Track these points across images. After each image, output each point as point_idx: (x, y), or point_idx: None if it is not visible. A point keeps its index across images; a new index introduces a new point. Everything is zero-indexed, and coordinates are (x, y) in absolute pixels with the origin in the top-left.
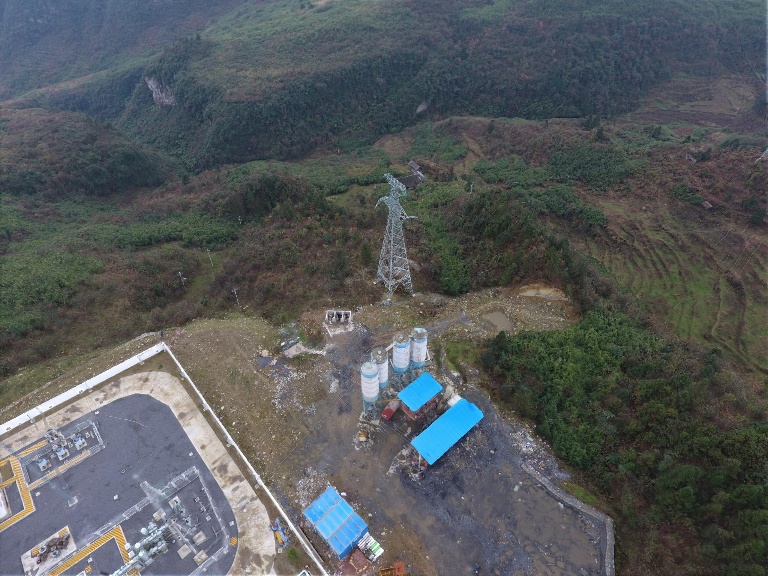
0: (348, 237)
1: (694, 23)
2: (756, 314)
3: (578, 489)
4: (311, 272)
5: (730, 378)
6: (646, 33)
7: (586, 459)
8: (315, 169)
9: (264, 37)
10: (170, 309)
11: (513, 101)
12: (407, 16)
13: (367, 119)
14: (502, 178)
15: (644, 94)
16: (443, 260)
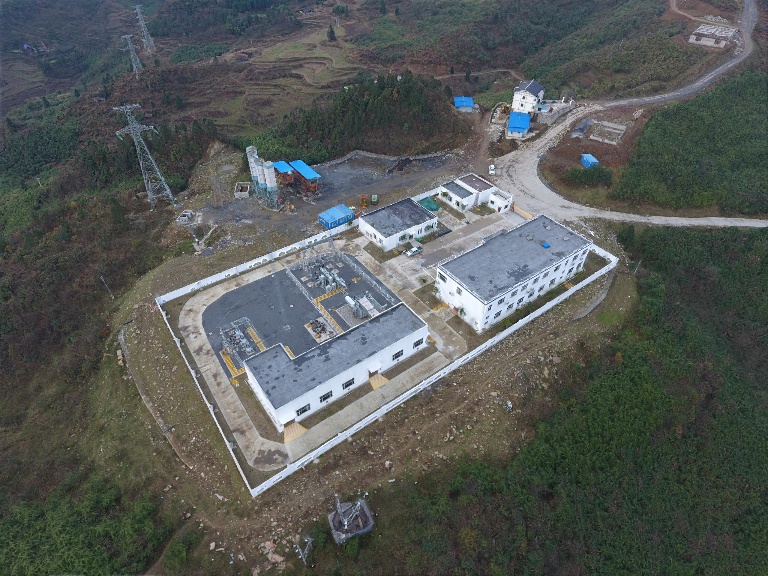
0: (72, 225)
1: None
2: None
3: None
4: None
5: None
6: None
7: None
8: None
9: None
10: (69, 355)
11: None
12: None
13: None
14: None
15: None
16: None
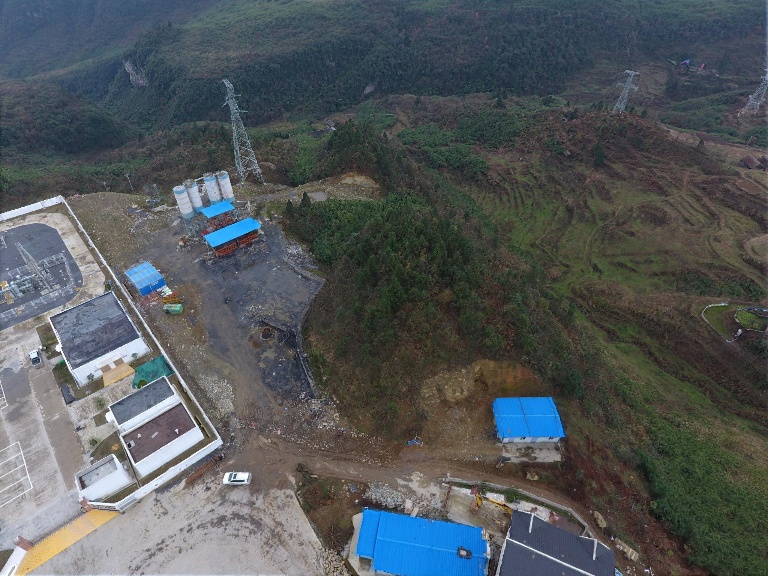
0: None
1: (615, 15)
2: (576, 229)
3: (318, 272)
4: (190, 168)
5: (455, 220)
6: (571, 24)
7: (332, 259)
8: (251, 129)
9: (228, 25)
10: None
11: (450, 83)
12: (358, 7)
13: (318, 98)
14: (416, 140)
15: (570, 79)
16: (298, 165)
